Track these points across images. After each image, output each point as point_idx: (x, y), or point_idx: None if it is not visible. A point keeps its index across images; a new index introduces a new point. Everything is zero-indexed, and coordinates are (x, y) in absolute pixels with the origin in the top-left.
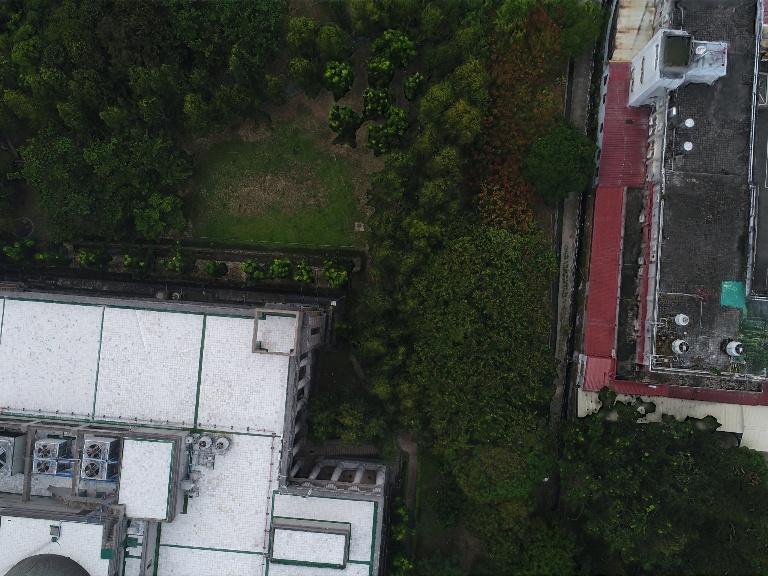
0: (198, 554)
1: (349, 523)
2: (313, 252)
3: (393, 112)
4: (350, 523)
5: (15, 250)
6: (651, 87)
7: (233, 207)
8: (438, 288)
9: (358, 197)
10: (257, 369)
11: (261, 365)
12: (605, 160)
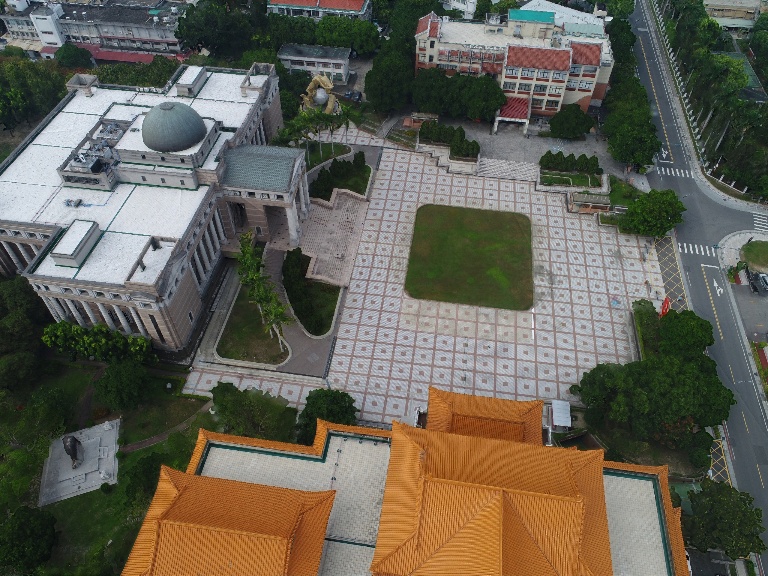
0: None
1: None
2: None
3: (10, 94)
4: None
5: None
6: (54, 25)
7: None
8: None
9: None
10: None
11: None
12: None
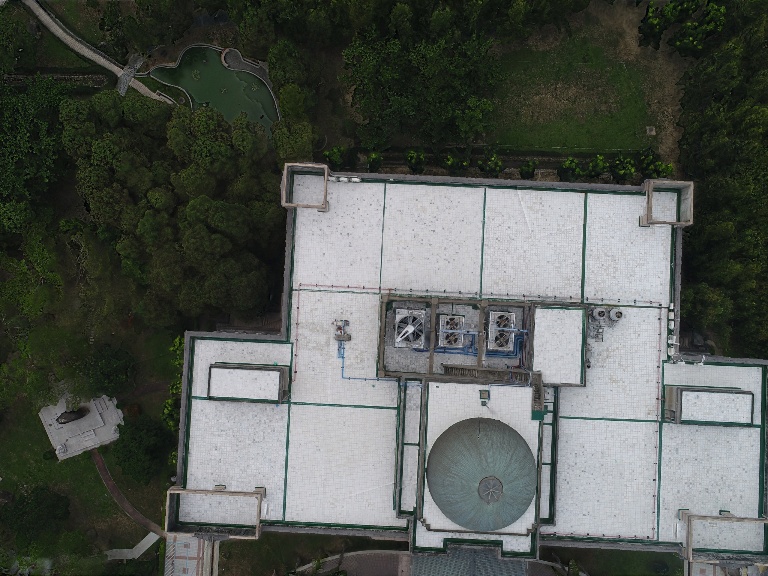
0: (592, 424)
1: (739, 388)
2: (608, 156)
3: (712, 8)
4: (740, 388)
5: (338, 153)
6: None
7: (526, 115)
8: (766, 175)
9: (649, 102)
10: (640, 243)
11: (644, 239)
12: None
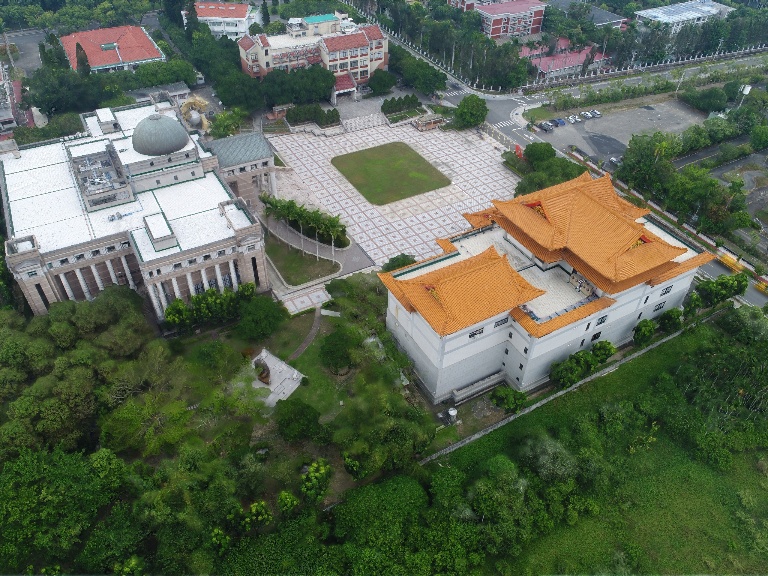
0: None
1: None
2: None
3: None
4: None
5: None
6: None
7: None
8: None
9: None
10: None
11: (28, 155)
12: None
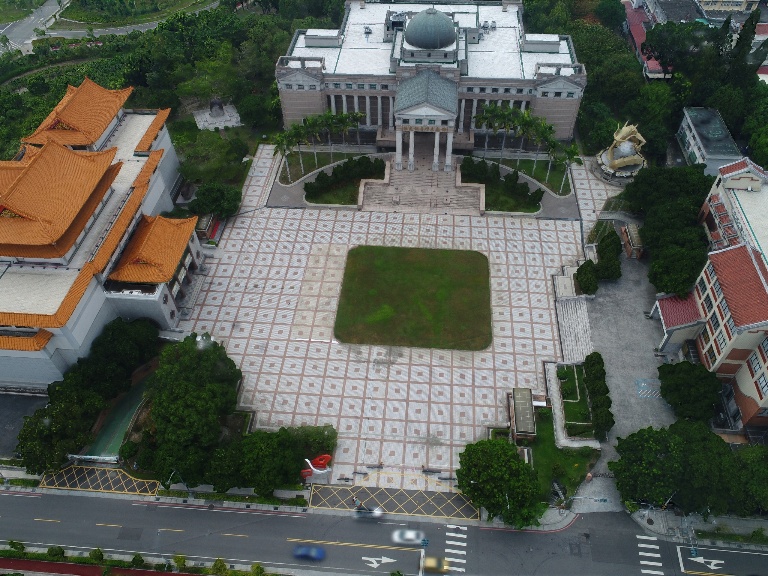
0: None
1: None
2: None
3: None
4: None
5: None
6: None
7: None
8: None
9: None
10: None
11: (505, 14)
12: (630, 20)
